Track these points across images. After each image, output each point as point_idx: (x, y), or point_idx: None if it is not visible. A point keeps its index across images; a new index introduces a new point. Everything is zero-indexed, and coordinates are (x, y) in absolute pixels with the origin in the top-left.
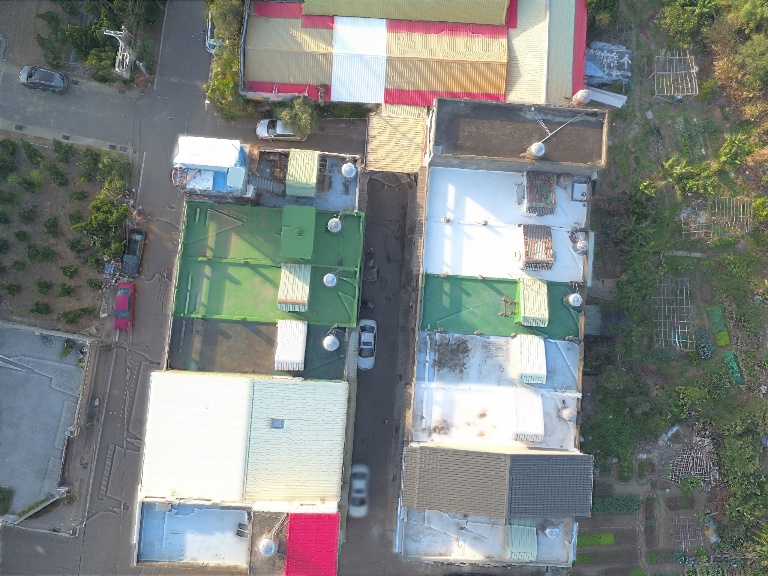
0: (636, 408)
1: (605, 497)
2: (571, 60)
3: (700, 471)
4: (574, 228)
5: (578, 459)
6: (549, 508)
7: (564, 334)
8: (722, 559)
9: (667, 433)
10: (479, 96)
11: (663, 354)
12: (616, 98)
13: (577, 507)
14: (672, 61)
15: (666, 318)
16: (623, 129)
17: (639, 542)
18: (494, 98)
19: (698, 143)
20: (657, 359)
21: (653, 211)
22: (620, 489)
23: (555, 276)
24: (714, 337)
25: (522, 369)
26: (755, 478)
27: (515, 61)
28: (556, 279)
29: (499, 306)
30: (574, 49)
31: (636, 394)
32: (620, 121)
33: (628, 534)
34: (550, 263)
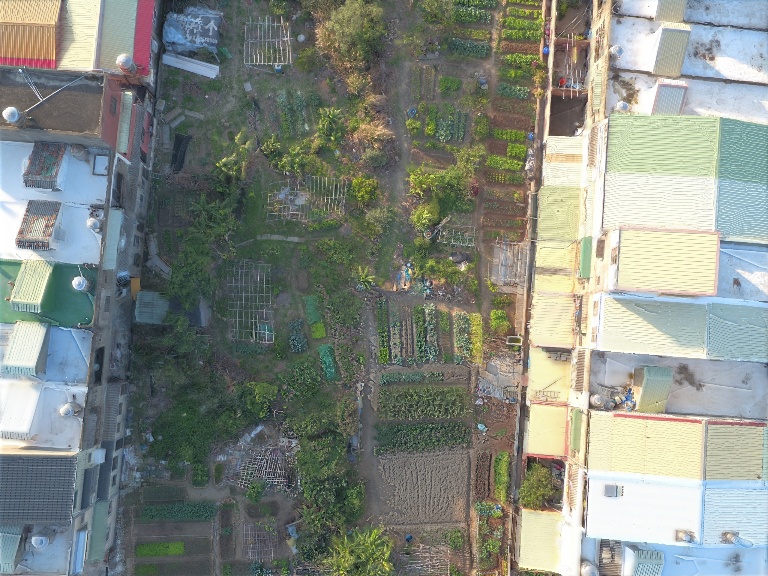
0: (204, 405)
1: (176, 502)
2: (133, 24)
3: (274, 475)
4: (91, 205)
5: (57, 459)
6: (16, 514)
7: (77, 321)
8: (304, 572)
9: (250, 433)
10: (27, 62)
11: (248, 347)
12: (207, 68)
13: (54, 513)
14: (264, 28)
15: (243, 307)
16: (216, 102)
17: (213, 552)
18: (44, 64)
19: (300, 118)
20: (242, 352)
21: (237, 190)
22: (195, 494)
23: (71, 257)
24: (309, 329)
25: (9, 359)
26: (333, 483)
27: (66, 24)
28: (71, 261)
29: (5, 290)
30: (138, 12)
31: (211, 390)
32: (214, 93)
33: (200, 543)
34: (45, 242)
